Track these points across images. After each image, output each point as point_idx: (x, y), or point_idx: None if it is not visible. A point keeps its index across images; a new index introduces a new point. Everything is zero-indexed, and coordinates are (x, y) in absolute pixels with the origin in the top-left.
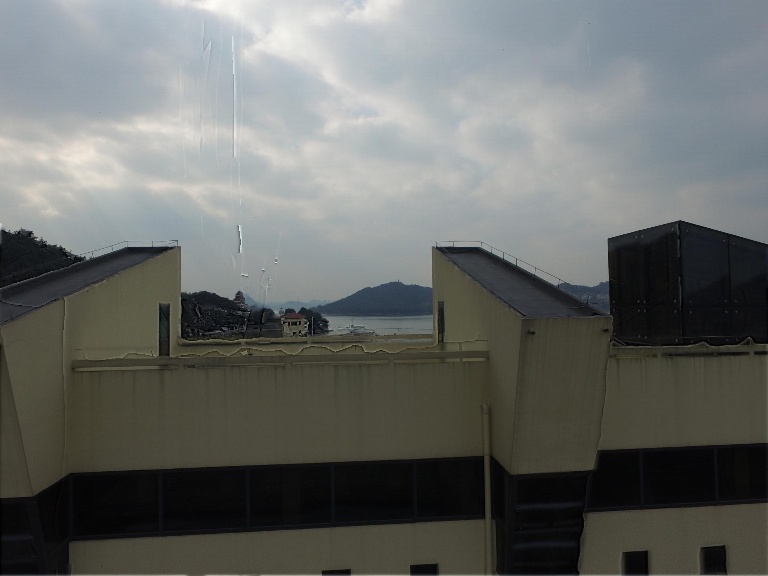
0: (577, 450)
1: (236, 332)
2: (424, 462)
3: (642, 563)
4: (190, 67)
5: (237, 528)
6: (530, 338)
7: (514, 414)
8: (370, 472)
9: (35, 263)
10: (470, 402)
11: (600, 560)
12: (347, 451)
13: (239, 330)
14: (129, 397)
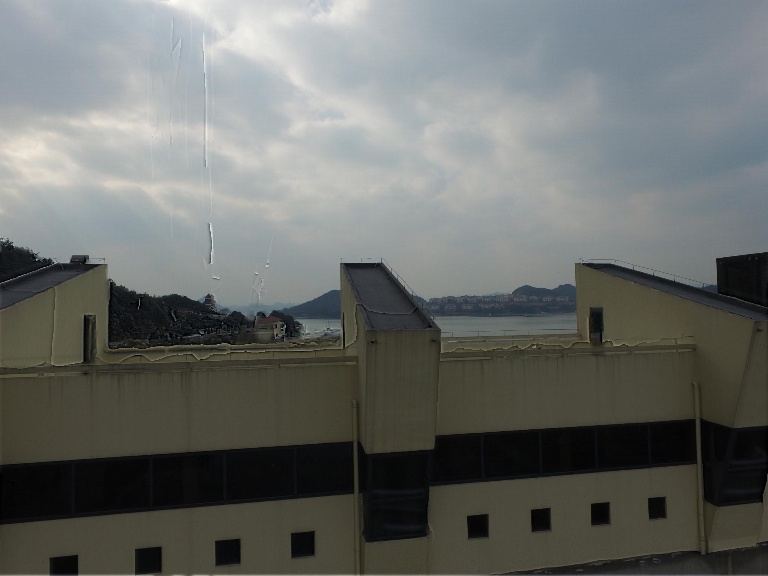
0: None
1: (215, 336)
2: (655, 424)
3: None
4: (158, 64)
5: (534, 474)
6: (758, 334)
7: (741, 386)
8: (620, 432)
9: (4, 265)
10: (684, 381)
11: None
12: (605, 417)
13: (216, 334)
14: (460, 380)
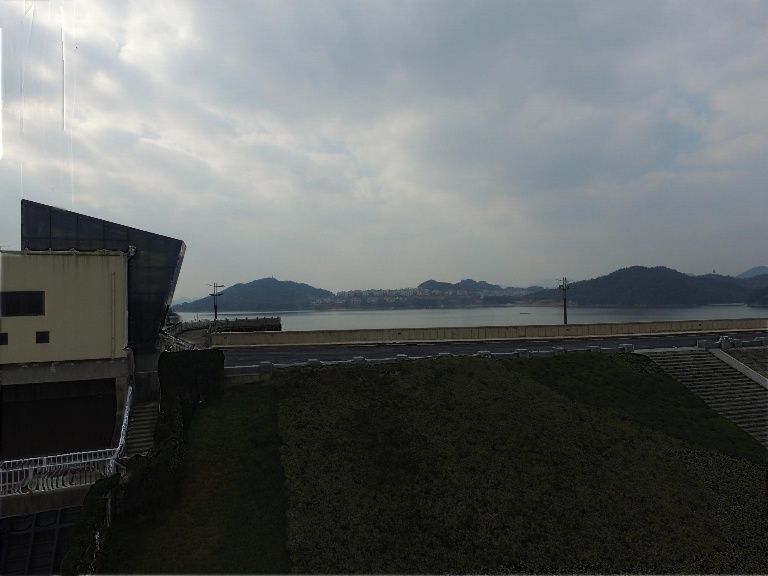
0: None
1: None
2: None
3: None
4: (8, 30)
5: None
6: None
7: None
8: None
9: None
10: None
11: None
12: None
13: None
14: None
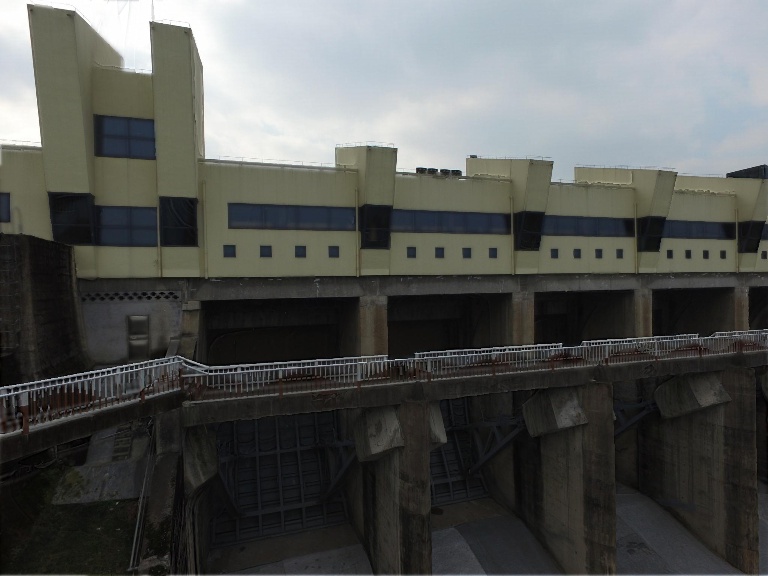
0: (764, 215)
1: None
2: (723, 223)
3: (766, 254)
4: None
5: (686, 238)
6: None
7: (756, 204)
8: (712, 225)
9: None
10: (732, 208)
11: (758, 253)
12: (707, 219)
13: None
14: None
